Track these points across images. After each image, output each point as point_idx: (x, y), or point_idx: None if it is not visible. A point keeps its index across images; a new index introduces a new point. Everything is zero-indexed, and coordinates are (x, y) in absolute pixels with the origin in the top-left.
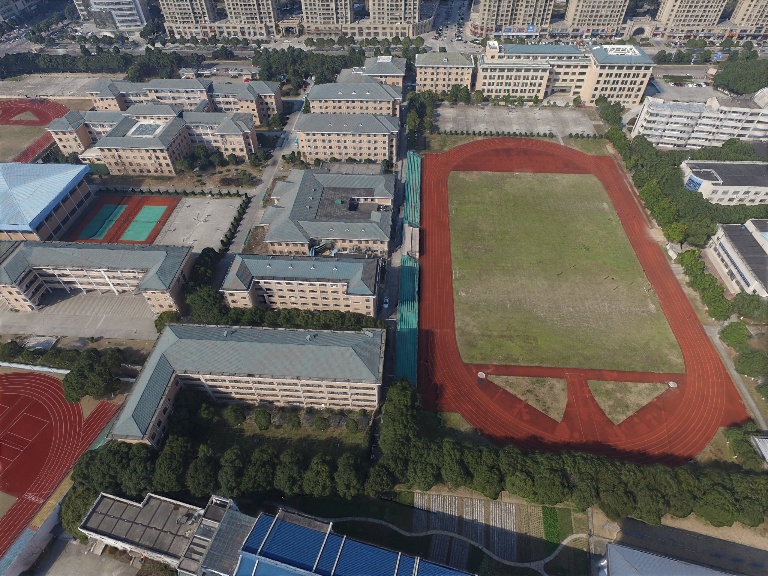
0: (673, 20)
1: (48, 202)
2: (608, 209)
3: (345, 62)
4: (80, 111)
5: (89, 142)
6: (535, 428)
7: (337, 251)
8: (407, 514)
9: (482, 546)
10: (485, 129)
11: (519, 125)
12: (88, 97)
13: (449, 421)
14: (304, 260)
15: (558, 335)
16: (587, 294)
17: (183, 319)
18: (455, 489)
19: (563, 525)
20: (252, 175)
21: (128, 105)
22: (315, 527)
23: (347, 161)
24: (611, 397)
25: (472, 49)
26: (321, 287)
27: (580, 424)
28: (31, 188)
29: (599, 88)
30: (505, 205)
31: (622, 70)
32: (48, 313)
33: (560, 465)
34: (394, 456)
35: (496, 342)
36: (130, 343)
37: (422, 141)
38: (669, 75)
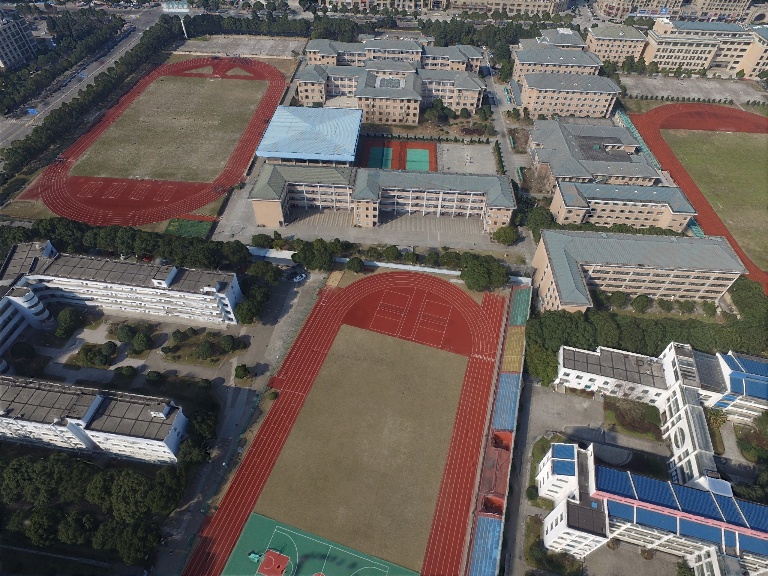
0: None
1: (355, 138)
2: None
3: (516, 33)
4: (322, 65)
5: (326, 94)
6: None
7: None
8: None
9: None
10: (668, 95)
11: (696, 93)
12: (286, 57)
13: None
14: None
15: None
16: None
17: None
18: None
19: None
20: None
21: (340, 64)
22: (766, 362)
23: None
24: None
25: None
26: (642, 208)
27: None
28: (331, 127)
29: (761, 63)
30: (724, 156)
31: None
32: (388, 229)
33: None
34: None
35: None
36: (476, 252)
37: None
38: None
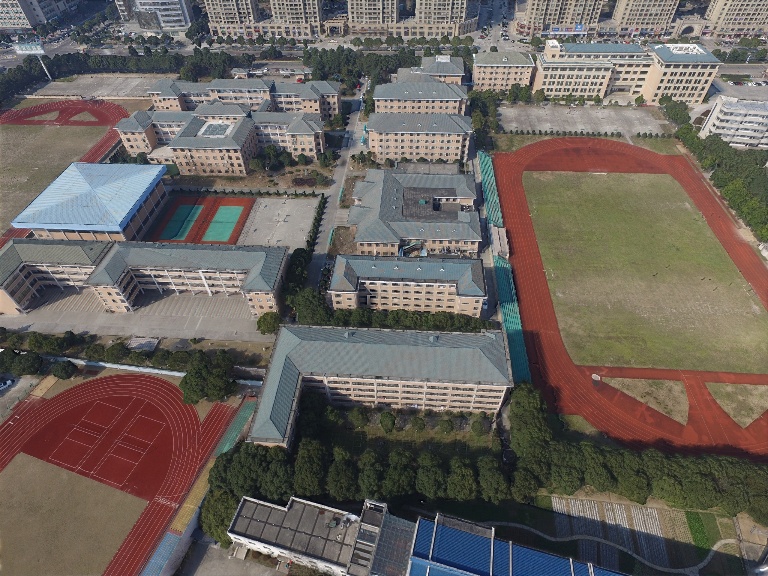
0: (724, 19)
1: (134, 202)
2: (691, 209)
3: (399, 62)
4: (147, 111)
5: (155, 142)
6: (661, 431)
7: (426, 252)
8: (548, 519)
9: (631, 551)
10: (550, 129)
11: (584, 124)
12: (143, 97)
13: (572, 424)
14: (409, 261)
15: (666, 337)
16: (687, 295)
17: (285, 320)
18: (592, 493)
19: (710, 530)
20: (323, 175)
21: (188, 105)
22: (478, 532)
23: (419, 161)
24: (733, 400)
25: (521, 48)
26: (427, 288)
27: (707, 427)
28: (114, 188)
29: (662, 87)
30: (586, 205)
31: (687, 69)
32: (144, 314)
33: (707, 469)
34: (537, 460)
35: (604, 344)
36: (233, 344)
37: (488, 141)
38: (727, 74)
